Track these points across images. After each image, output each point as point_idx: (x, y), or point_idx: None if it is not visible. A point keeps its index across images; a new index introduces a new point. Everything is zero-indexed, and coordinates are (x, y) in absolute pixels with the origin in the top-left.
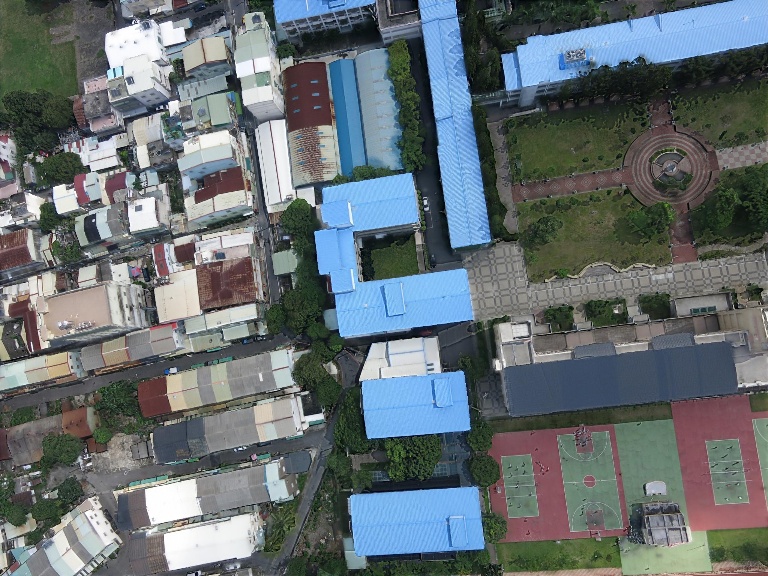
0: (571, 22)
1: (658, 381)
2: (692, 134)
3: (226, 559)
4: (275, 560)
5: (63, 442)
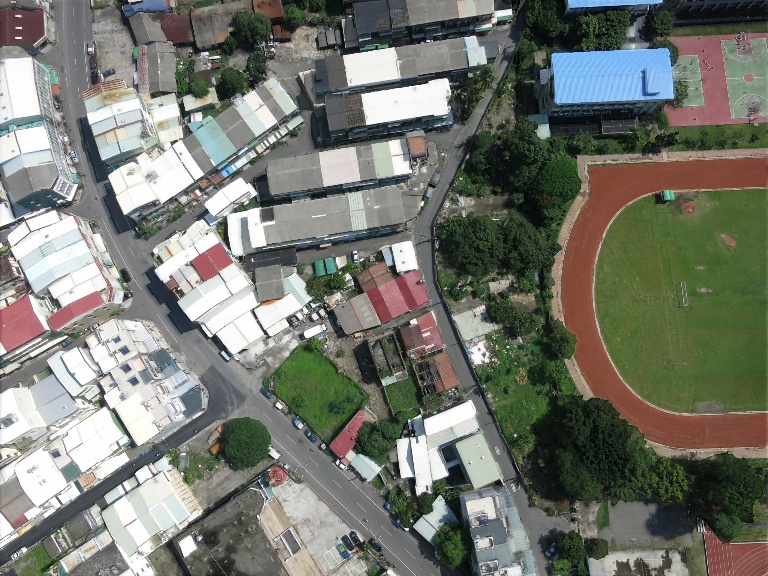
0: None
1: None
2: None
3: (424, 115)
4: (458, 140)
5: (257, 14)
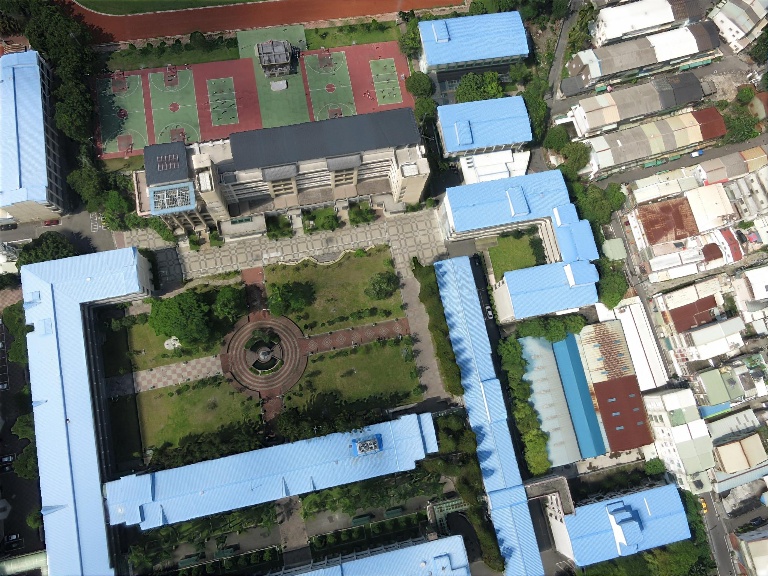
0: (370, 491)
1: (293, 139)
2: (244, 389)
3: (620, 6)
4: (576, 17)
5: None
